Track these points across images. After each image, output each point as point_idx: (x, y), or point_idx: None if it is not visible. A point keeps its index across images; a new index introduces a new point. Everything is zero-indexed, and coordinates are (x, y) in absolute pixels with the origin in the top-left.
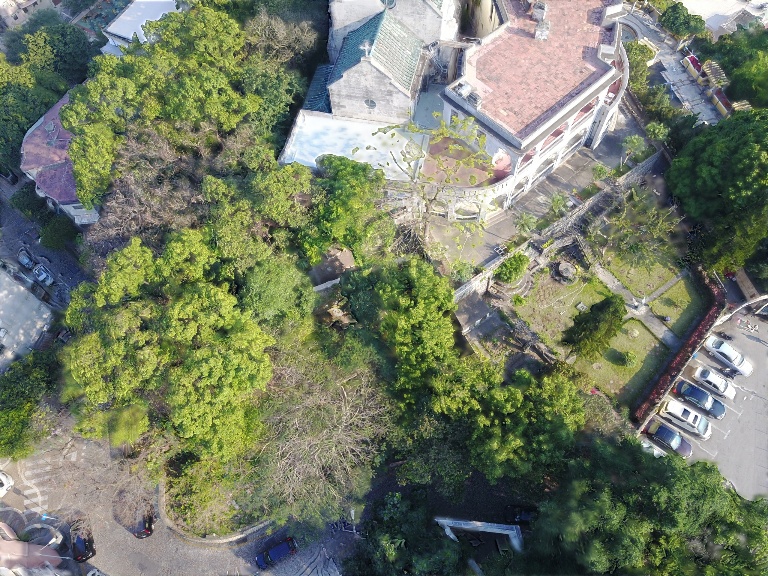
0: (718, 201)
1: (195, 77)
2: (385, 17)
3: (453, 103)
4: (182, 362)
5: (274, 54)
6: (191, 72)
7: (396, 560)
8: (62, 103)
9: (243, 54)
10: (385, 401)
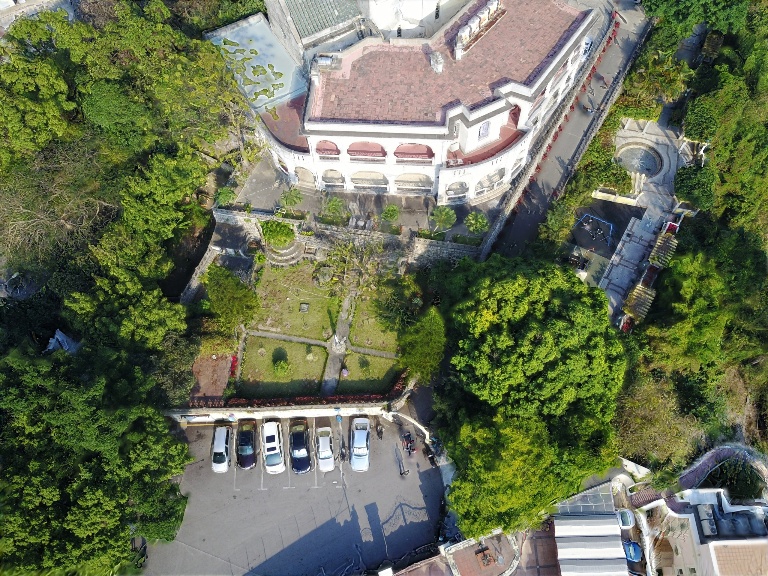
0: None
1: None
2: None
3: None
4: None
5: None
6: None
7: None
8: None
9: None
10: None
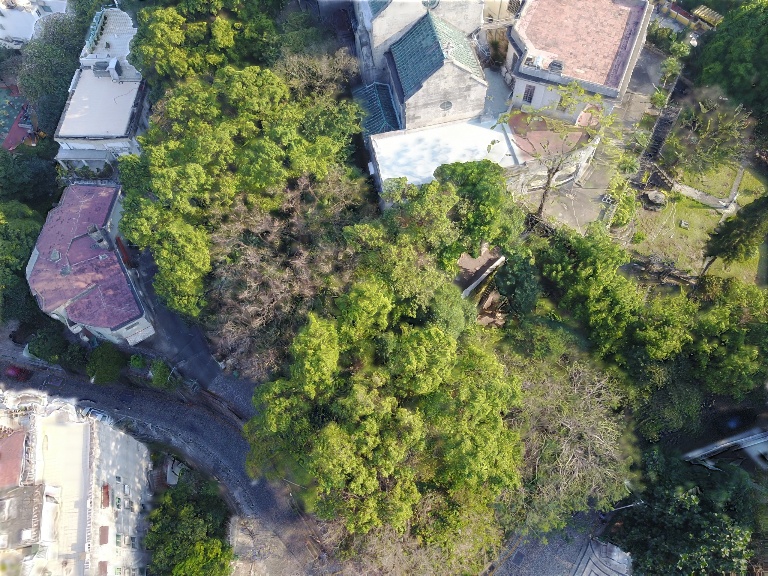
0: (753, 92)
1: (268, 137)
2: (431, 18)
3: (531, 78)
4: (443, 413)
5: (318, 91)
6: (250, 135)
7: (703, 508)
8: (50, 227)
9: (285, 102)
10: (601, 373)
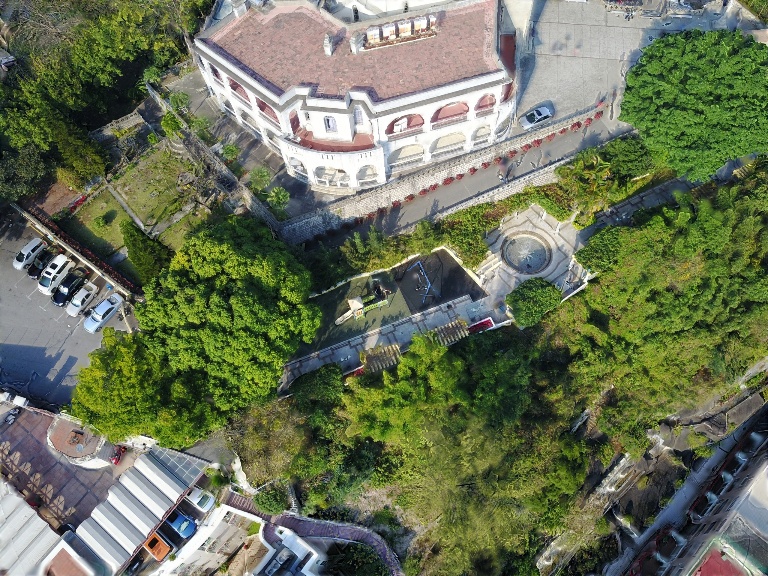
0: None
1: None
2: None
3: None
4: None
5: None
6: None
7: None
8: None
9: None
10: None
